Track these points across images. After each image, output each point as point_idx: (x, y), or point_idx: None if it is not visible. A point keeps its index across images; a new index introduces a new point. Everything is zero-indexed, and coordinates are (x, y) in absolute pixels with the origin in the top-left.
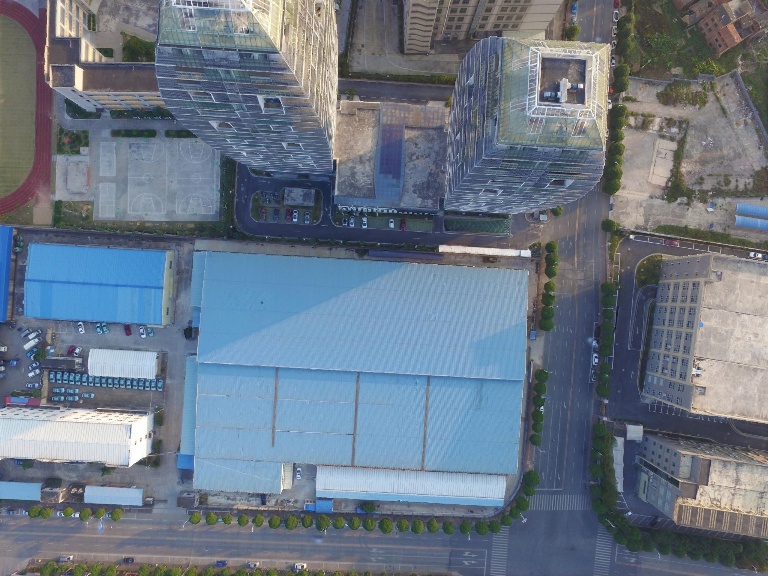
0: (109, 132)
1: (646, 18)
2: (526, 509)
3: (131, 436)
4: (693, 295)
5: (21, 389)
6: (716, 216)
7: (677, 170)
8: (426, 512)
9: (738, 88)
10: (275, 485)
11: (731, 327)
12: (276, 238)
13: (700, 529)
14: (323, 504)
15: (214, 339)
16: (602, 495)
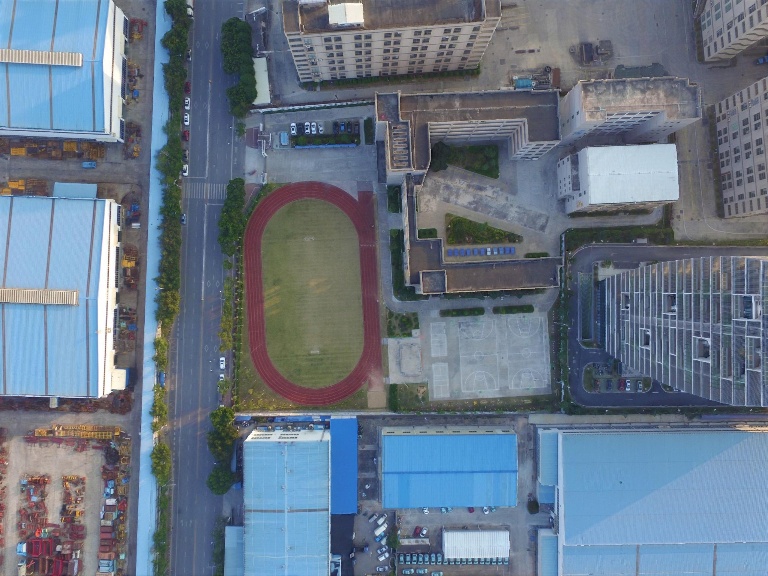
0: (438, 312)
1: None
2: None
3: None
4: None
5: (371, 573)
6: None
7: None
8: None
9: None
10: None
11: None
12: (610, 408)
13: None
14: None
15: (578, 522)
16: None
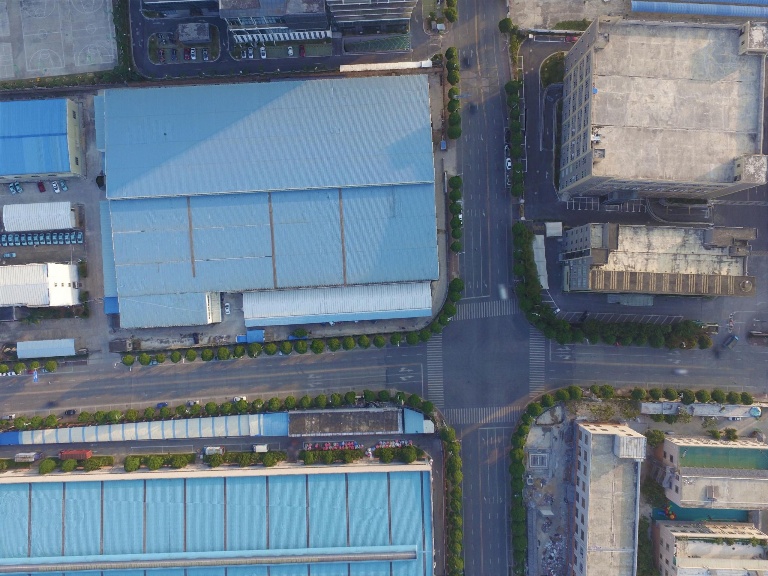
0: None
1: None
2: (453, 314)
3: (48, 275)
4: (587, 68)
5: None
6: (613, 6)
7: None
8: (358, 333)
9: None
10: (201, 315)
11: (626, 91)
12: (177, 78)
13: (630, 319)
14: (254, 334)
15: (121, 175)
16: (525, 289)
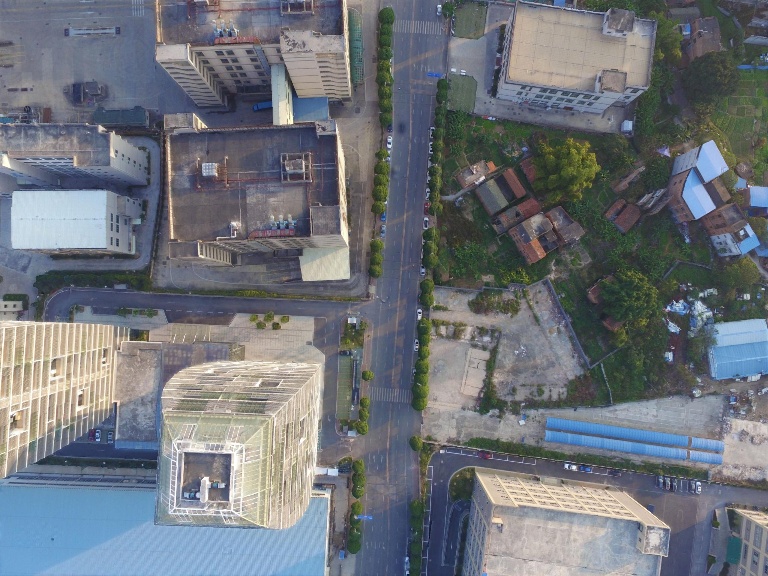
0: None
1: (456, 226)
2: None
3: None
4: (482, 537)
5: None
6: (529, 428)
7: (489, 381)
8: None
9: (551, 295)
10: None
11: (518, 575)
12: (79, 458)
13: None
14: None
15: None
16: None
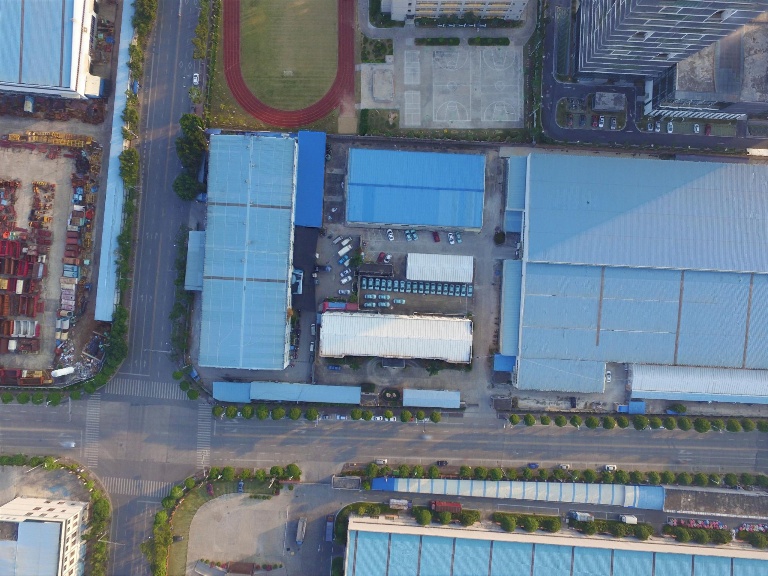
0: (413, 41)
1: None
2: None
3: None
4: None
5: (333, 296)
6: None
7: None
8: (733, 414)
9: None
10: (598, 384)
11: None
12: None
13: None
14: (637, 405)
15: (543, 238)
16: None
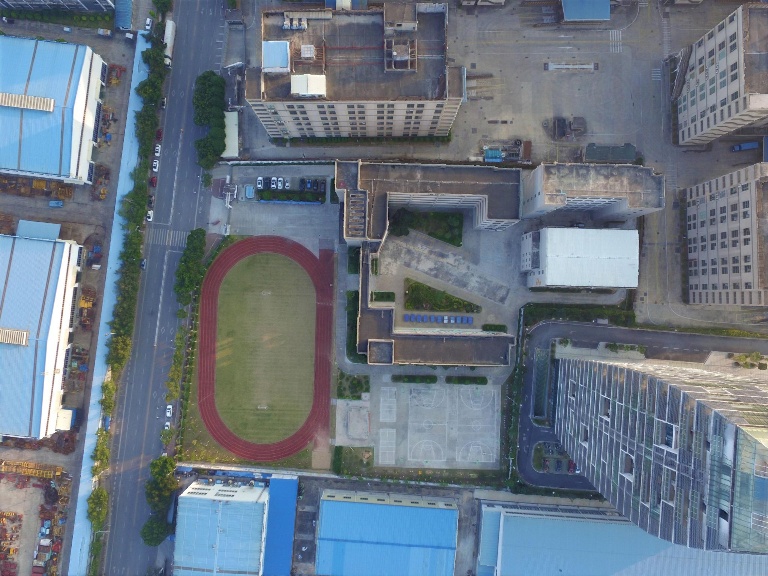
0: (390, 377)
1: None
2: None
3: None
4: None
5: None
6: None
7: None
8: None
9: None
10: None
11: None
12: (558, 489)
13: None
14: None
15: None
16: None
